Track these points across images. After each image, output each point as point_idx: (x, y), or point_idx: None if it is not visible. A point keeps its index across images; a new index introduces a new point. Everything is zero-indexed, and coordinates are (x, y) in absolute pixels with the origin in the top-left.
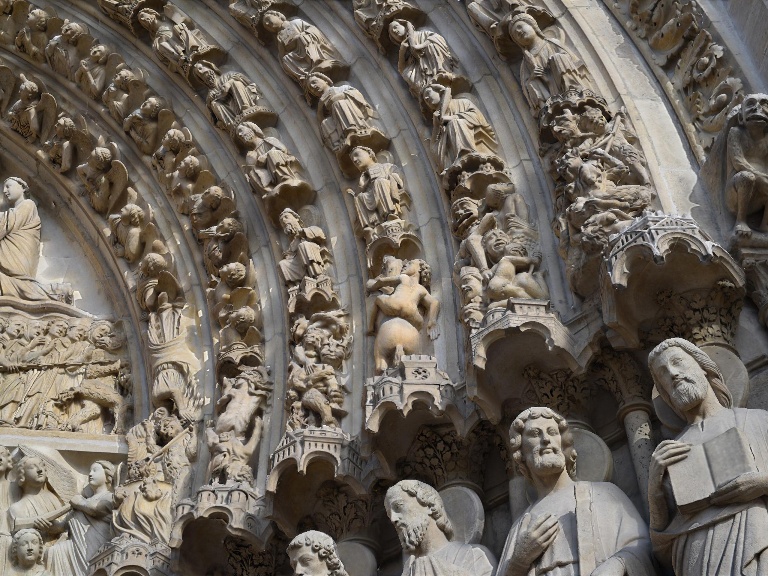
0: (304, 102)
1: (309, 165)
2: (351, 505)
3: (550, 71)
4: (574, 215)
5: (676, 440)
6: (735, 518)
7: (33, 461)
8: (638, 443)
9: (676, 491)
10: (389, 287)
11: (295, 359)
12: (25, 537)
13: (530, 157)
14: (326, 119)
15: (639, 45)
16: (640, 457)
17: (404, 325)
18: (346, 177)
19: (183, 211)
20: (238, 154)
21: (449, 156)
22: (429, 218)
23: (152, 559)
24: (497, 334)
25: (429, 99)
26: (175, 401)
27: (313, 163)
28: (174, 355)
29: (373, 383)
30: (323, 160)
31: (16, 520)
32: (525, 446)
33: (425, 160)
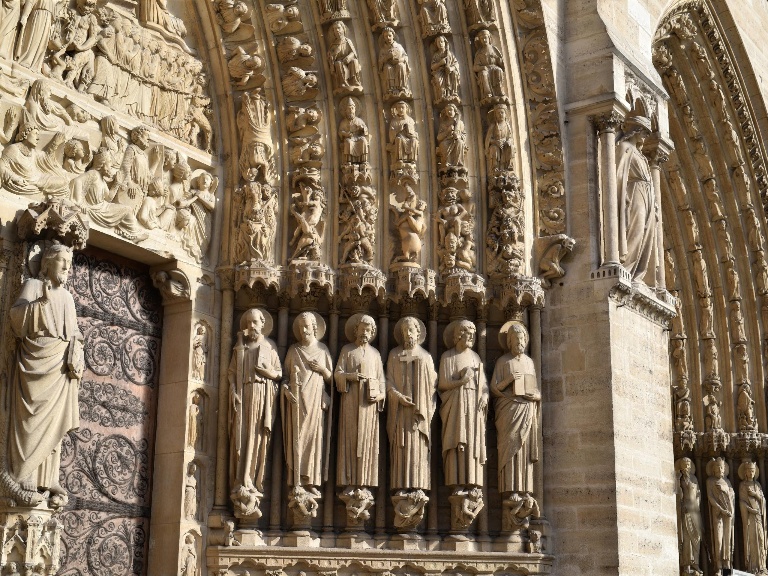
0: (370, 26)
1: (363, 72)
2: (368, 296)
3: (506, 149)
4: (507, 254)
5: (510, 360)
6: (527, 404)
7: (189, 170)
8: (483, 337)
9: (516, 389)
10: (414, 213)
11: (359, 215)
12: (188, 217)
13: (477, 175)
14: (391, 67)
15: (532, 147)
16: (483, 343)
17: (420, 242)
18: (384, 101)
19: (274, 31)
20: (321, 24)
21: (451, 156)
22: (425, 170)
23: (278, 278)
24: (471, 290)
25: (451, 113)
26: (265, 171)
27: (366, 73)
28: (266, 140)
29: (412, 272)
30: (371, 74)
31: (181, 203)
32: (464, 335)
33: (427, 127)
